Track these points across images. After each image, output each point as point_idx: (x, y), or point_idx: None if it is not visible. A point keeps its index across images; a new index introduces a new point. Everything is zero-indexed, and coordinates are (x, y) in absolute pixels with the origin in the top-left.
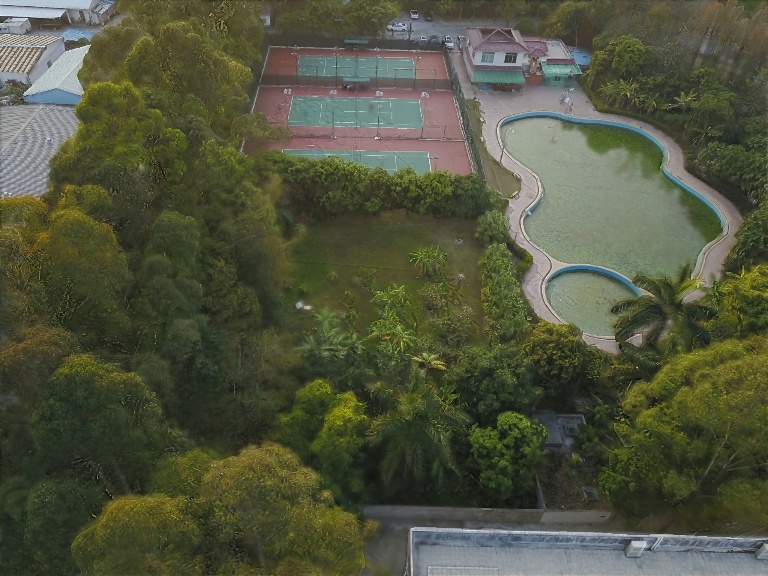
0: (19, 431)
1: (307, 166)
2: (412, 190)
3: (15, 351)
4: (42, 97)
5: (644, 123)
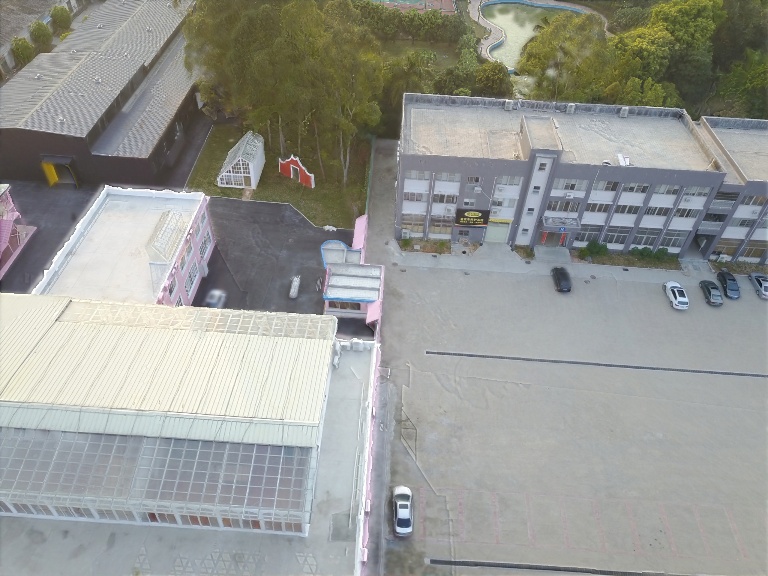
0: None
1: None
2: (416, 20)
3: None
4: None
5: (585, 7)
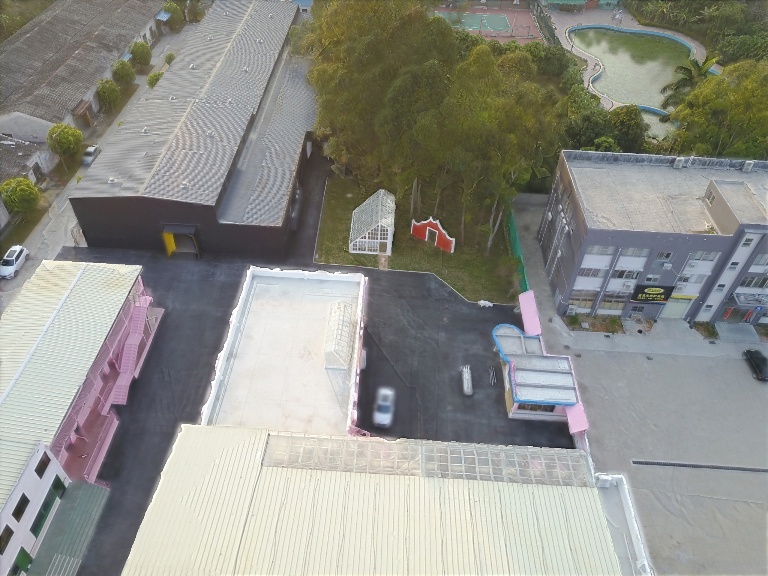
0: (411, 47)
1: None
2: None
3: (416, 8)
4: None
5: (676, 32)
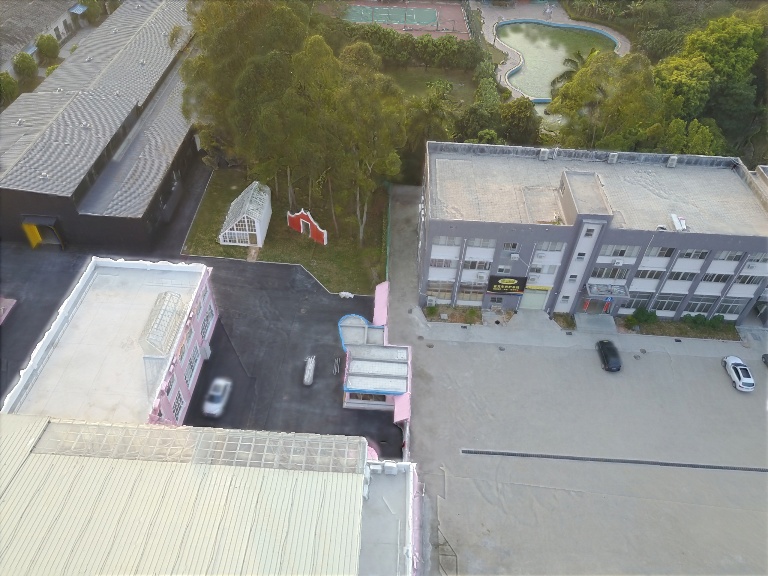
0: (258, 38)
1: (359, 26)
2: (430, 46)
3: None
4: None
5: (605, 27)
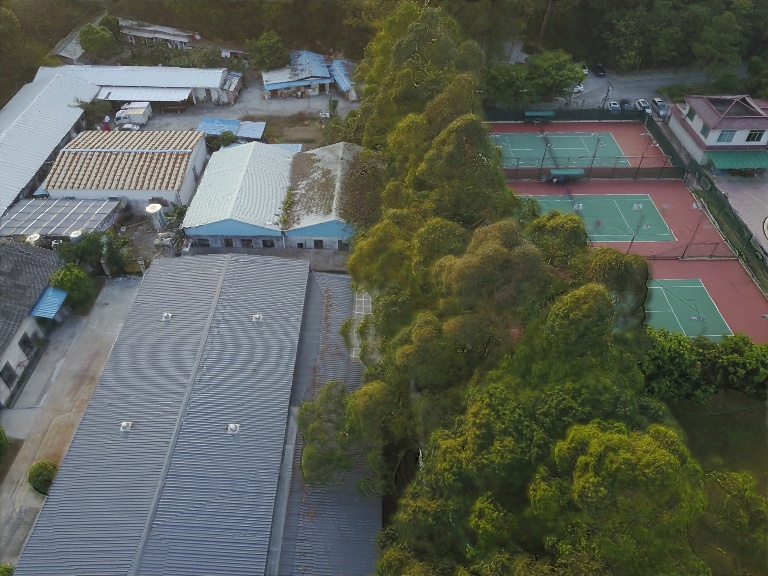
0: None
1: None
2: (762, 374)
3: None
4: (208, 228)
5: None
